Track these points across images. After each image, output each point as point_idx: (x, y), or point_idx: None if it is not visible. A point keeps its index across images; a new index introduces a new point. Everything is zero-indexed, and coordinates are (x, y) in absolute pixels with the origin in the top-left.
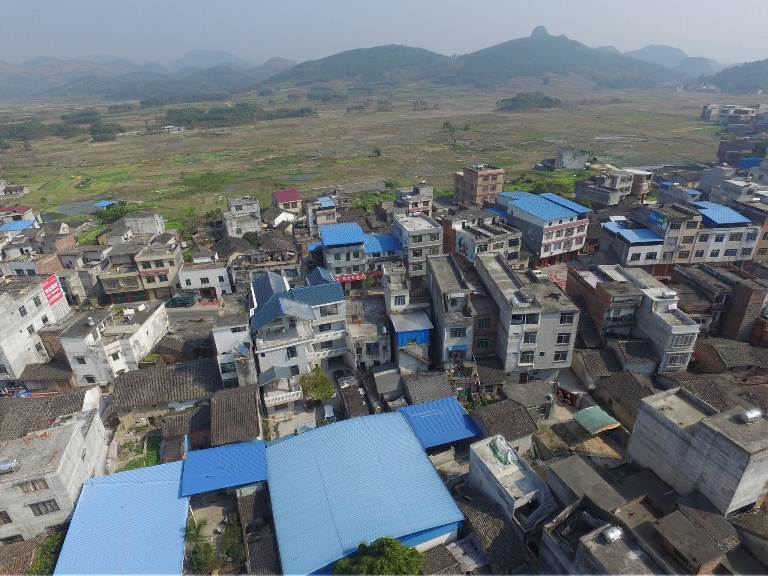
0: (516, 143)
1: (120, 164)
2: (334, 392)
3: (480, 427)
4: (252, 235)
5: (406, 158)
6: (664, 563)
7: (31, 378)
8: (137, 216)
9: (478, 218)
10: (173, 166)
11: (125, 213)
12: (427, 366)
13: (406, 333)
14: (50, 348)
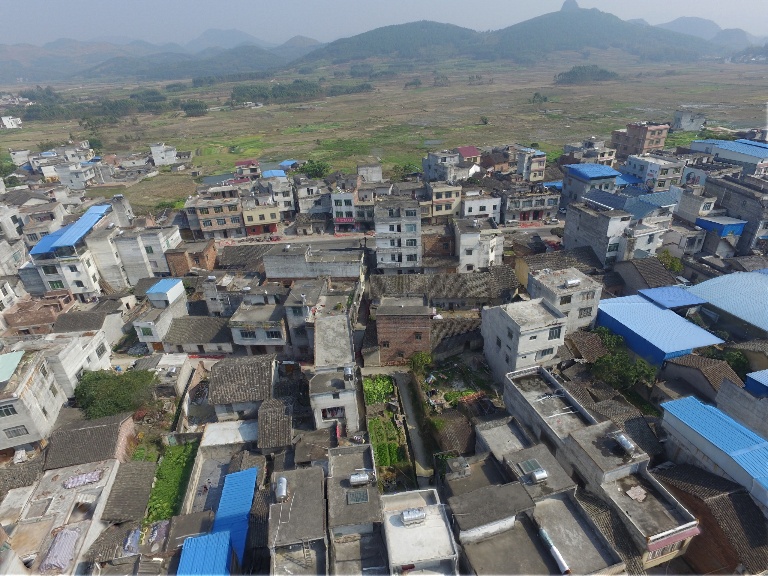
0: (607, 111)
1: (243, 134)
2: (683, 267)
3: None
4: (475, 180)
5: (514, 125)
6: None
7: (430, 266)
8: (368, 166)
9: (698, 158)
10: (296, 135)
11: (323, 169)
12: (733, 254)
13: (730, 226)
14: (423, 248)
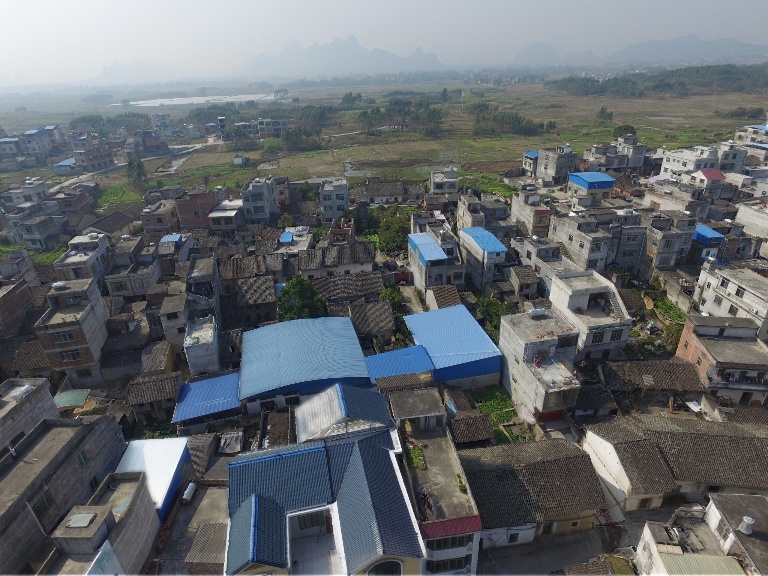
0: None
1: None
2: None
3: (179, 388)
4: None
5: None
6: (188, 268)
7: None
8: None
9: None
10: None
11: None
12: None
13: None
14: None
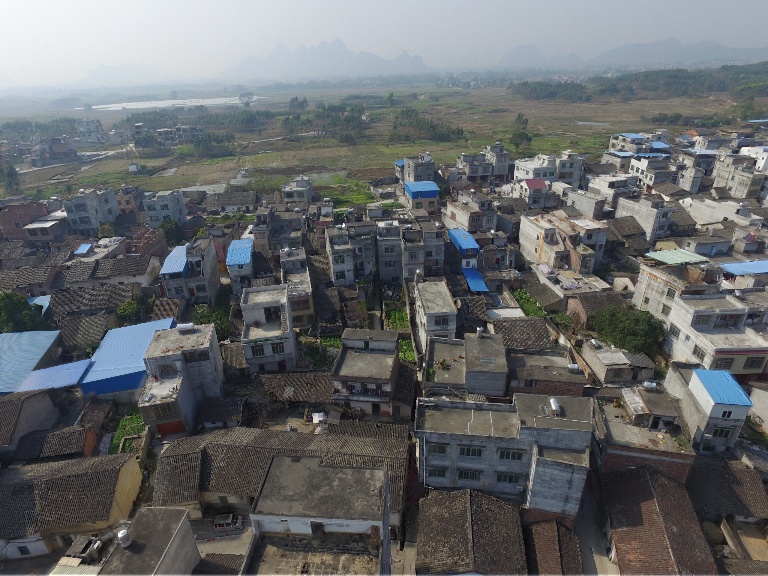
0: None
1: None
2: None
3: None
4: None
5: None
6: None
7: None
8: None
9: None
10: None
11: None
12: None
13: None
14: None
